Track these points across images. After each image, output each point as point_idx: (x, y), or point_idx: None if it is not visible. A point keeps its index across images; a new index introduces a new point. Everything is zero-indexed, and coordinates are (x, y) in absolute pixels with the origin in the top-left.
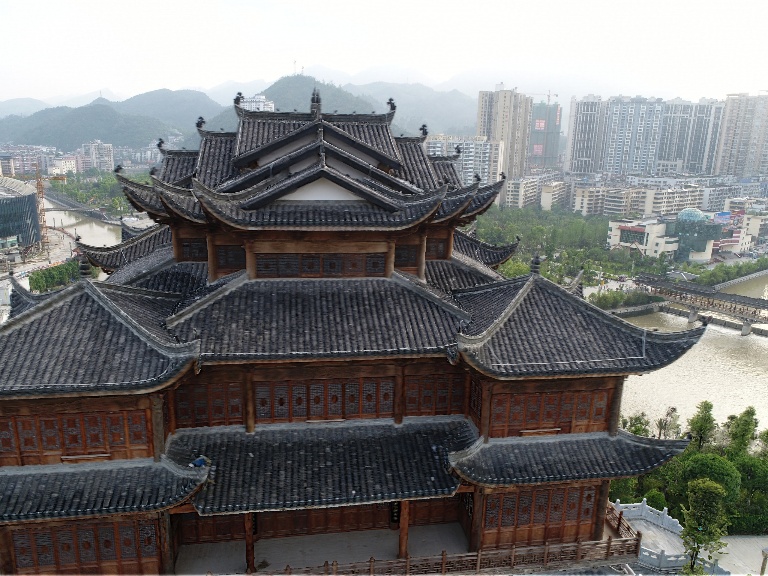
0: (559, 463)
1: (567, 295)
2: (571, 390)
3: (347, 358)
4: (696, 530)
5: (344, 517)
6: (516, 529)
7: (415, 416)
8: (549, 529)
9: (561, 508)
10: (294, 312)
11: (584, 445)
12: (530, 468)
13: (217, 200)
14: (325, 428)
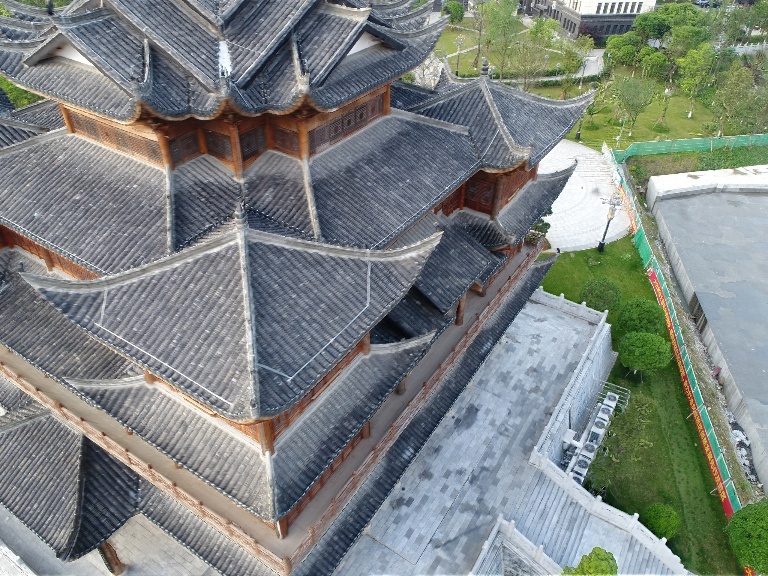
0: None
1: None
2: None
3: None
4: None
5: None
6: None
7: None
8: None
9: None
10: None
11: None
12: None
13: (397, 7)
14: None
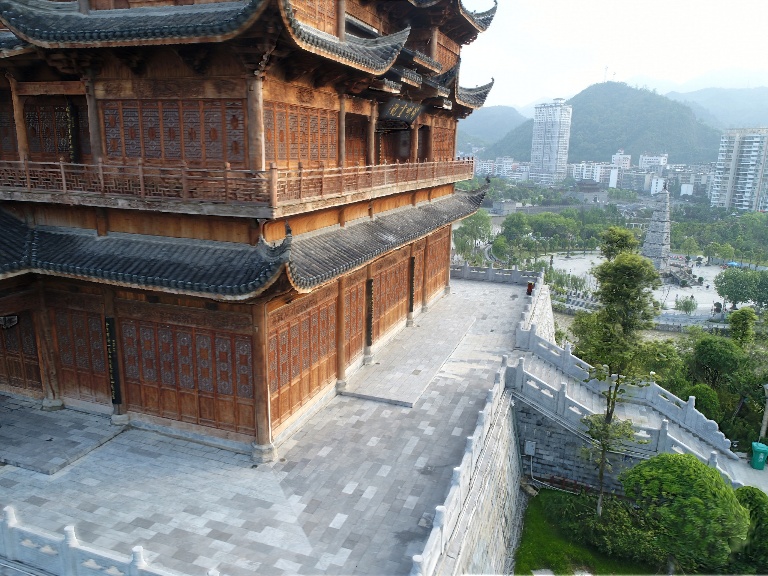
0: (143, 26)
1: None
2: None
3: None
4: (602, 340)
5: None
6: (145, 163)
7: None
8: None
9: (198, 136)
10: None
11: None
12: None
13: None
14: None
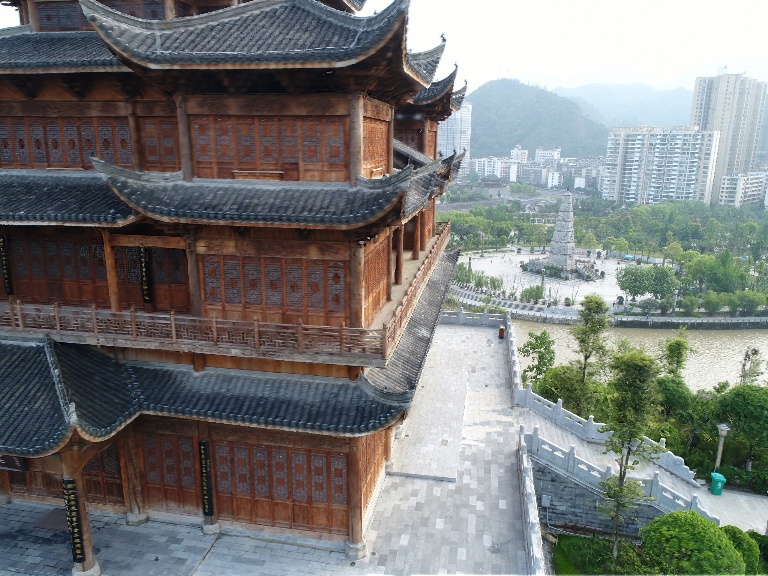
0: (261, 205)
1: (314, 5)
2: (288, 114)
3: (39, 70)
4: (617, 421)
5: (97, 290)
6: (245, 309)
7: (158, 172)
8: (288, 316)
9: (300, 288)
10: (36, 45)
11: (310, 194)
12: (221, 207)
13: None
14: (62, 176)
